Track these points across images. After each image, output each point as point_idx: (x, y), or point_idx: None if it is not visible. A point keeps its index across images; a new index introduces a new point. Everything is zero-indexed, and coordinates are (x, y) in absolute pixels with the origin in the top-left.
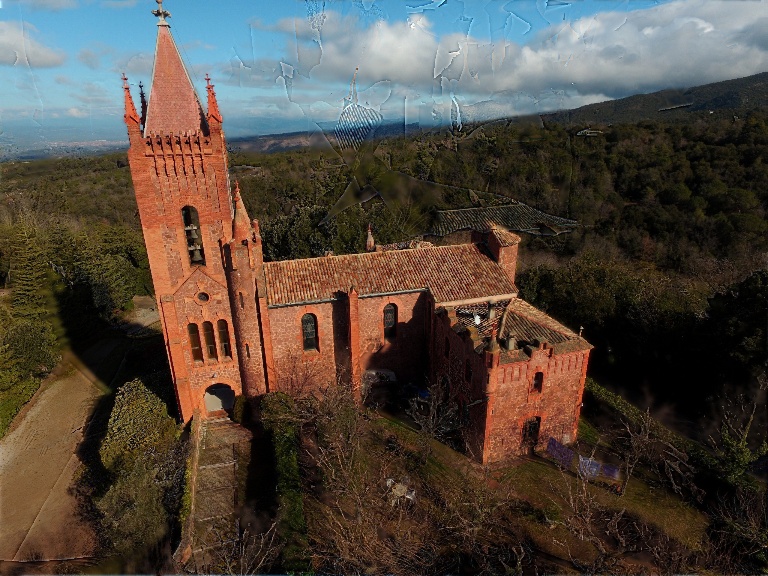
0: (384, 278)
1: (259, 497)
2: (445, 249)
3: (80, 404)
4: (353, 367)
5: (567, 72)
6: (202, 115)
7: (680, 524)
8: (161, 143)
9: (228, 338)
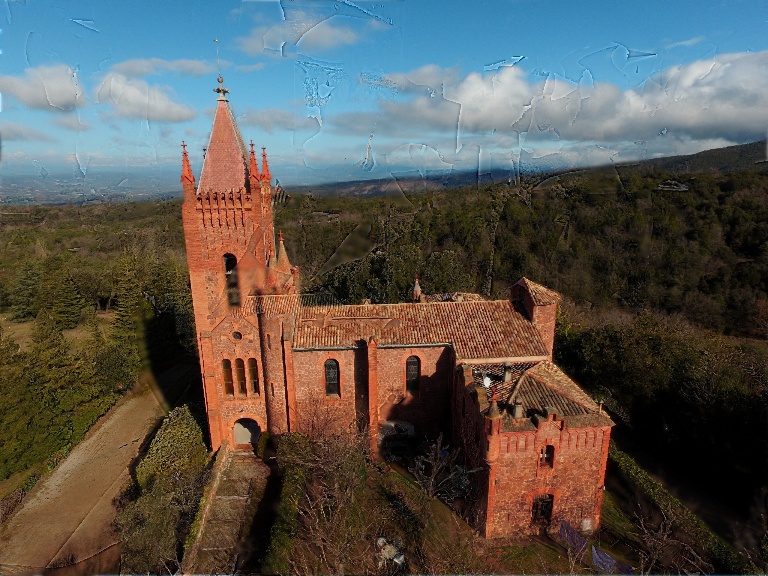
0: (408, 330)
1: (261, 535)
2: (477, 304)
3: (145, 422)
4: (370, 416)
5: (655, 122)
6: (247, 175)
7: None
8: (209, 199)
9: (258, 376)
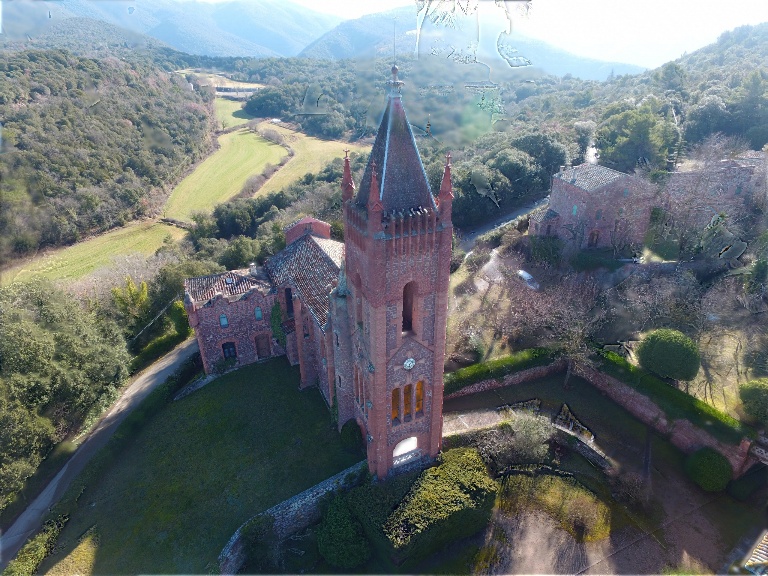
0: None
1: (479, 402)
2: None
3: None
4: None
5: None
6: None
7: (454, 279)
8: None
9: None
